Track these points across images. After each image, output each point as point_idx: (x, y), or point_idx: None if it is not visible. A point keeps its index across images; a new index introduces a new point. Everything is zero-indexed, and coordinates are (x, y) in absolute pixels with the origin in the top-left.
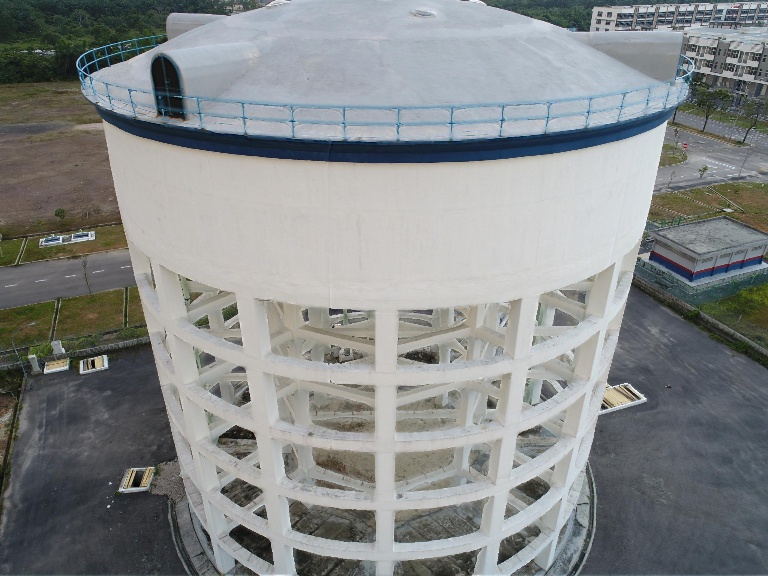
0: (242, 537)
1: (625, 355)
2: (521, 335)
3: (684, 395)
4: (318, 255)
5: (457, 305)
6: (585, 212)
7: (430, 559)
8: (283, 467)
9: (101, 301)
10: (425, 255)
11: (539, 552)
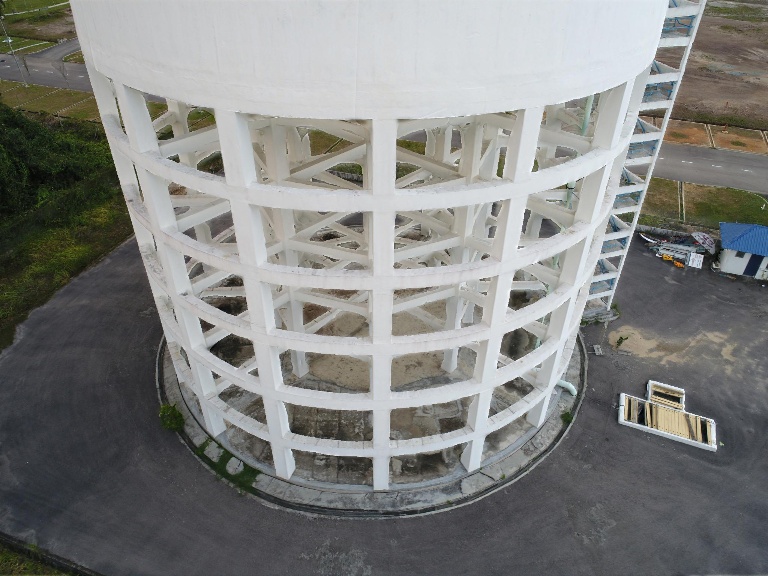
0: None
1: (762, 397)
2: (227, 156)
3: None
4: (80, 11)
5: (157, 93)
6: (277, 19)
7: (302, 414)
8: (150, 235)
9: (324, 135)
10: (122, 25)
11: (348, 455)
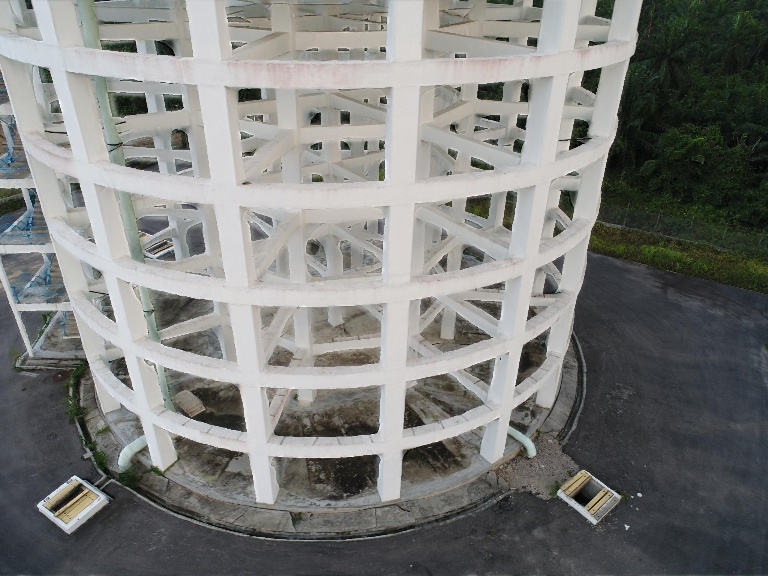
0: (525, 355)
1: None
2: None
3: None
4: None
5: None
6: None
7: None
8: None
9: None
10: None
11: None
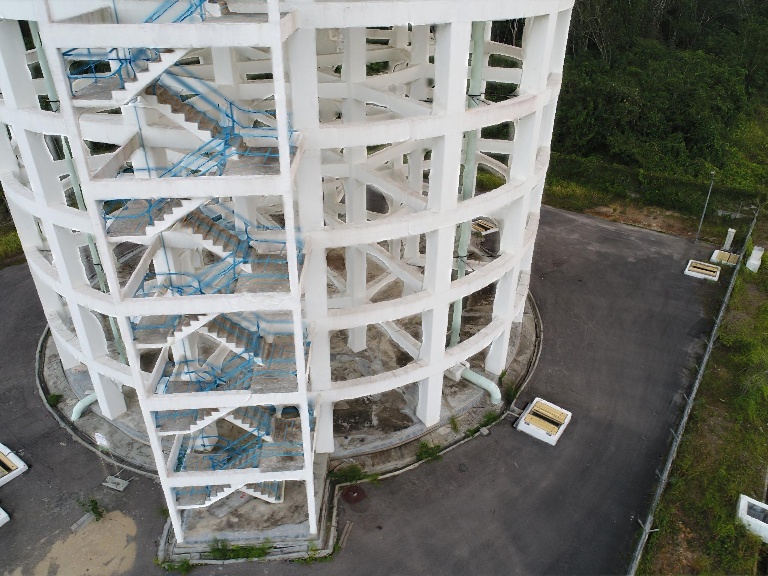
0: None
1: None
2: None
3: None
4: None
5: None
6: None
7: None
8: None
9: None
10: None
11: None
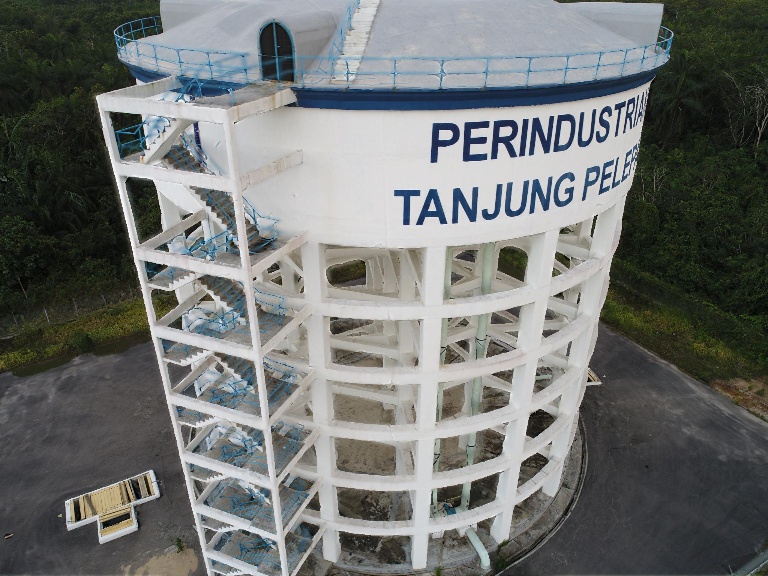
0: None
1: None
2: None
3: (2, 522)
4: None
5: None
6: None
7: None
8: None
9: None
10: None
11: None
